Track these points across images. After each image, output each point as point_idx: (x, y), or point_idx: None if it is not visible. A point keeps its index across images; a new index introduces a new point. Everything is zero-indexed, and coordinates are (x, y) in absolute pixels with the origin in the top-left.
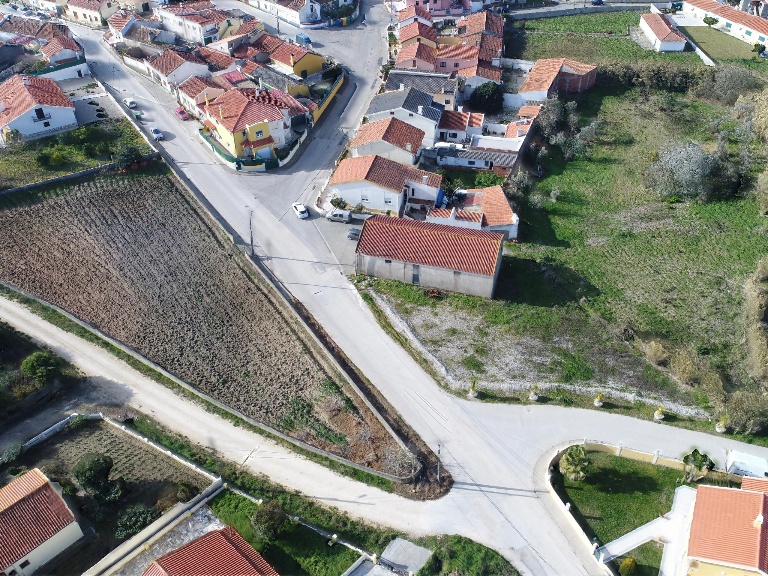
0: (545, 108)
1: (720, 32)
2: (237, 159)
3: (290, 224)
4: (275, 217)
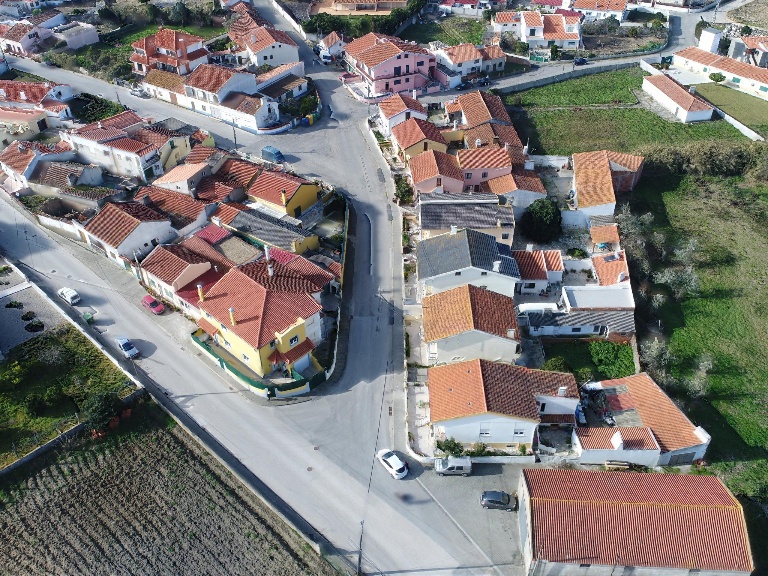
0: (622, 228)
1: (730, 89)
2: (267, 383)
3: (387, 494)
4: (360, 483)
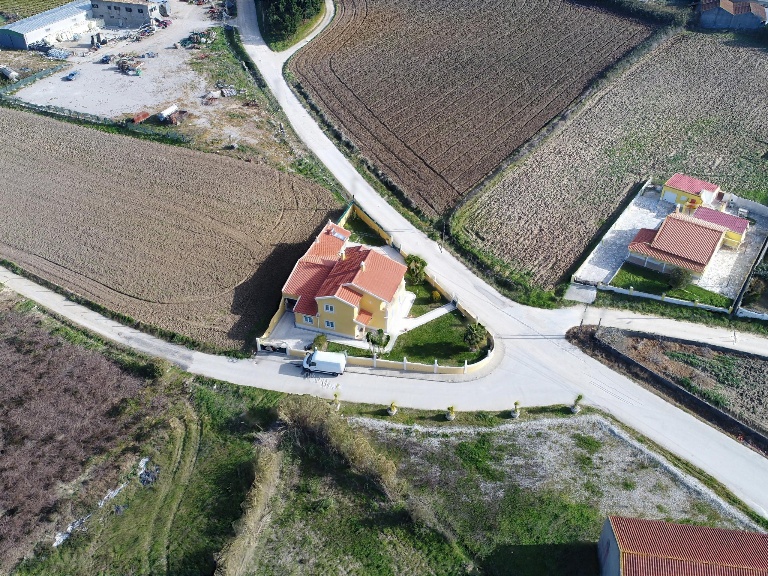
0: None
1: None
2: None
3: None
4: None
